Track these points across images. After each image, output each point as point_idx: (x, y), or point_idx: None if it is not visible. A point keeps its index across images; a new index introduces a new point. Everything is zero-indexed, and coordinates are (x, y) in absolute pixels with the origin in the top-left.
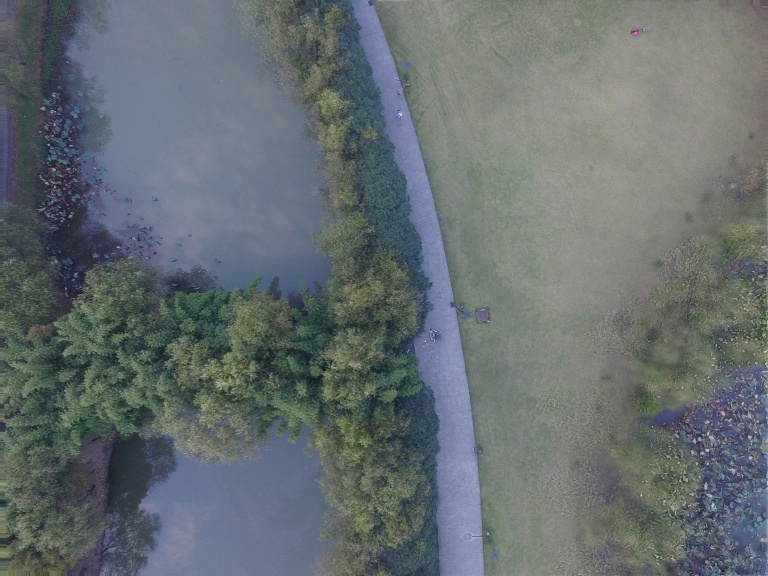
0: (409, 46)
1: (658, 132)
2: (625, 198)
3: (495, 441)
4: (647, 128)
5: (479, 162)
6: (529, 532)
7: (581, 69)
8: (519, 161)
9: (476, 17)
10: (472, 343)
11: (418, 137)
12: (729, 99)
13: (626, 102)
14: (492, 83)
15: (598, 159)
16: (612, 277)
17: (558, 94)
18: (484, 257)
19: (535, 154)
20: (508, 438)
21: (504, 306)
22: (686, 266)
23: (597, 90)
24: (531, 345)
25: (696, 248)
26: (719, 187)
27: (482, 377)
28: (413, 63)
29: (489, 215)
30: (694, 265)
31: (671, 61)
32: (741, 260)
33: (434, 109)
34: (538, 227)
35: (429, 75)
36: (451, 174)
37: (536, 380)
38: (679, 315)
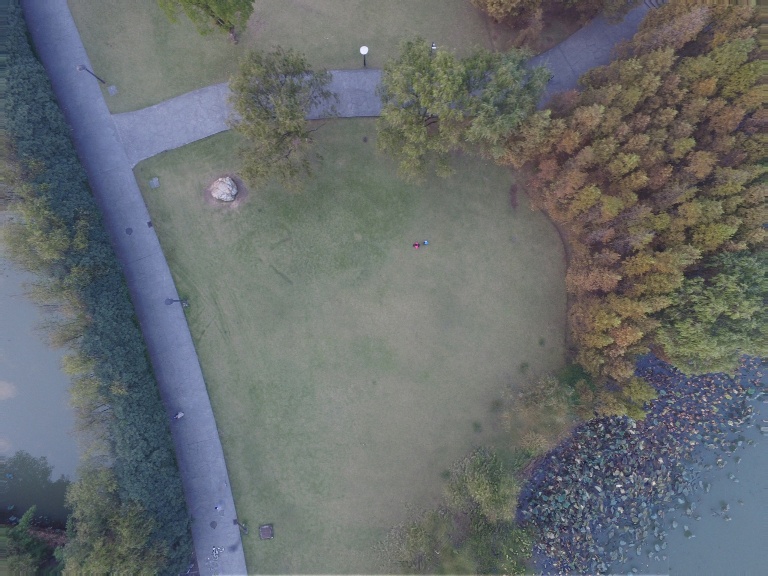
0: (188, 266)
1: (444, 343)
2: (410, 411)
3: None
4: (432, 340)
5: (260, 379)
6: None
7: (362, 284)
8: (300, 378)
9: (255, 236)
10: (256, 559)
11: (199, 356)
12: (518, 307)
13: (410, 315)
14: (272, 301)
15: (382, 373)
16: (398, 490)
17: (339, 310)
18: (267, 474)
19: (316, 370)
20: None
21: (288, 522)
22: (476, 476)
23: (379, 305)
24: (316, 560)
25: (486, 458)
26: (508, 397)
27: None
28: (193, 282)
29: (271, 432)
30: (484, 474)
31: (455, 272)
32: (534, 468)
33: (214, 328)
34: (320, 443)
35: (209, 294)
36: (232, 392)
37: None
38: (468, 526)
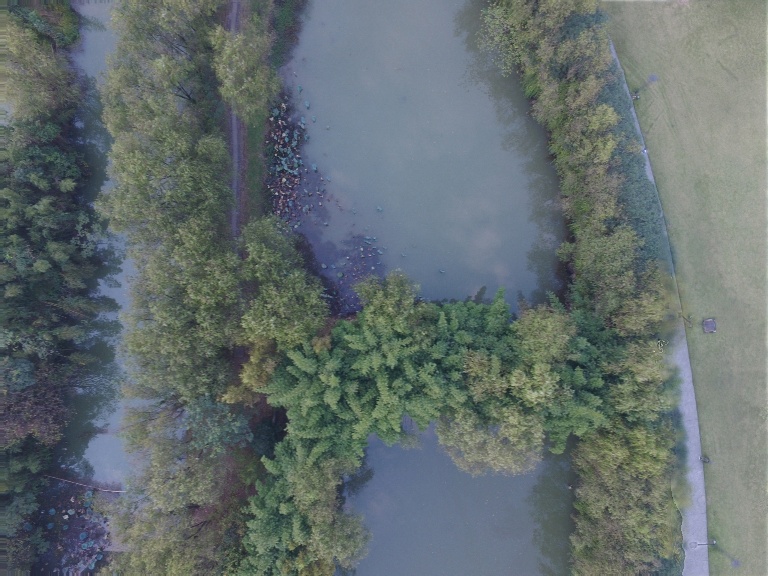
0: (638, 59)
1: None
2: None
3: (720, 450)
4: None
5: (706, 174)
6: (752, 540)
7: None
8: (744, 173)
9: (703, 31)
10: (698, 353)
11: (647, 149)
12: None
13: None
14: (718, 96)
15: None
16: None
17: None
18: (710, 268)
19: (760, 166)
20: (732, 447)
21: (729, 316)
22: None
23: None
24: (755, 355)
25: None
26: None
27: (708, 386)
28: (642, 76)
29: (716, 226)
30: None
31: None
32: None
33: (662, 121)
34: (763, 238)
35: (657, 88)
36: (679, 186)
37: (760, 389)
38: None
